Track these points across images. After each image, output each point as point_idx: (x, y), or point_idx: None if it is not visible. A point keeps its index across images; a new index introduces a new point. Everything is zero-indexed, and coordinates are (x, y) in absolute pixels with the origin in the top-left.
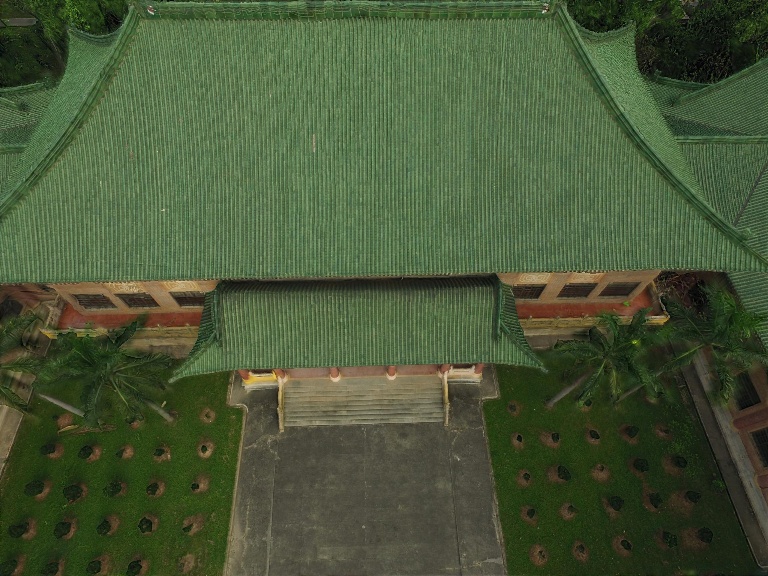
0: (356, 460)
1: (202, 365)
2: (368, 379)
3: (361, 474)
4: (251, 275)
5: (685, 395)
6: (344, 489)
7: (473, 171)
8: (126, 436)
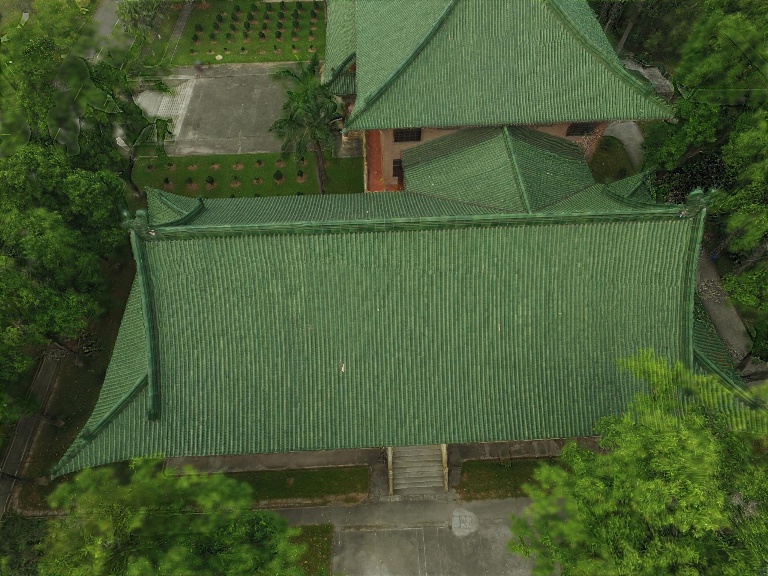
0: None
1: None
2: None
3: None
4: None
5: None
6: (286, 96)
7: None
8: (322, 27)
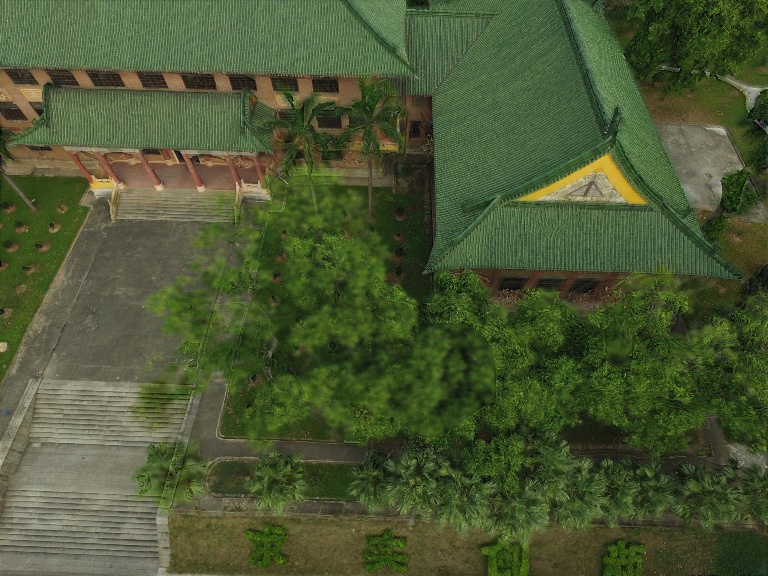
0: (162, 241)
1: (35, 139)
2: (184, 190)
3: (163, 249)
4: (60, 65)
5: (427, 218)
6: (147, 257)
7: (219, 3)
8: None
